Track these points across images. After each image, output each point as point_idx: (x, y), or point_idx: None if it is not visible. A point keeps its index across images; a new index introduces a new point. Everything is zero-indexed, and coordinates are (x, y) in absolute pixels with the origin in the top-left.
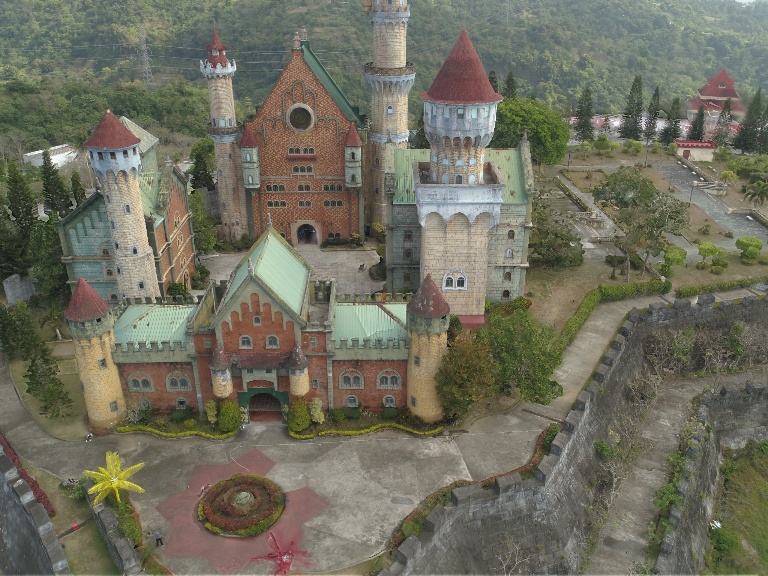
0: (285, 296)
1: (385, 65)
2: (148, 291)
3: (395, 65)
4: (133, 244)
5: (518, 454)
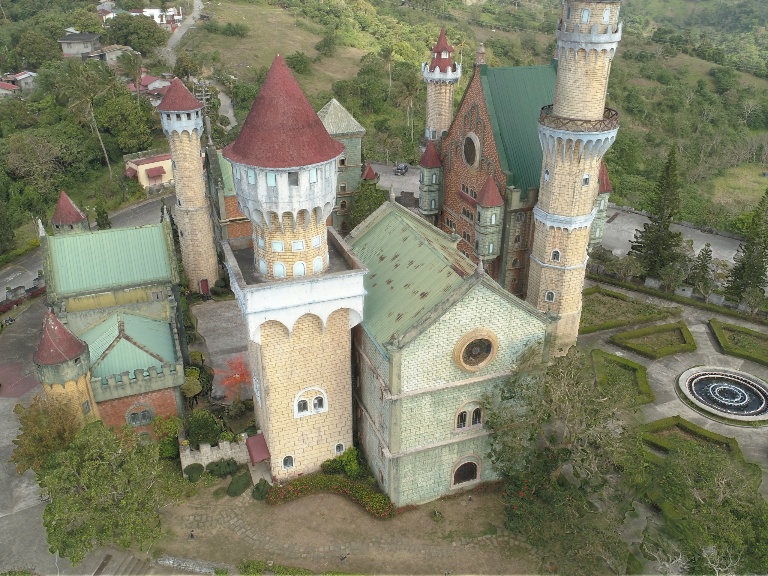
0: (73, 272)
1: (554, 109)
2: (187, 241)
3: (563, 112)
4: (179, 196)
5: (8, 561)
